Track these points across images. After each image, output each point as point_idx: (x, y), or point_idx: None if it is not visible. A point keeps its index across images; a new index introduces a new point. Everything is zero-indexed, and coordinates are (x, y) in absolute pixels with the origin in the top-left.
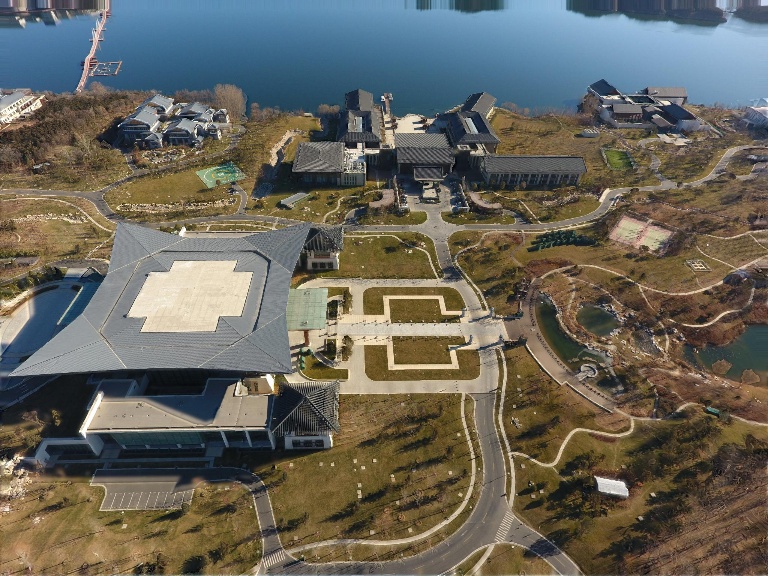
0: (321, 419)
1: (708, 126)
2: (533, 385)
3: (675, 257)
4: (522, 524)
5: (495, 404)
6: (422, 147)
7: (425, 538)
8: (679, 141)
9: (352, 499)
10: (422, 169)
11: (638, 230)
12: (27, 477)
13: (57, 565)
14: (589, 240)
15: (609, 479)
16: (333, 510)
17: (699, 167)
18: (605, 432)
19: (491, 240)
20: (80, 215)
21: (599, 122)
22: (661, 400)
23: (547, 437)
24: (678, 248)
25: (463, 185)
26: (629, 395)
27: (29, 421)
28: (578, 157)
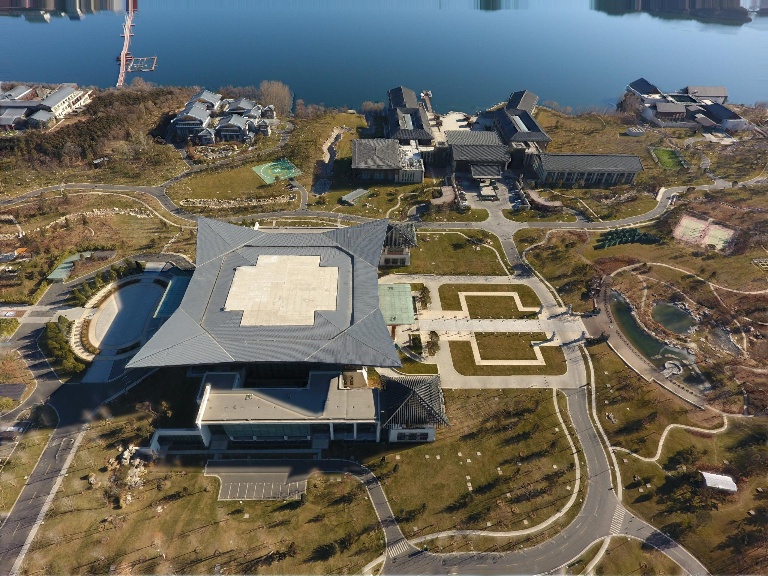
0: (430, 412)
1: (752, 126)
2: (622, 381)
3: (741, 256)
4: (634, 517)
5: (587, 399)
6: (476, 145)
7: (541, 530)
8: (725, 140)
9: (463, 491)
10: (479, 167)
11: (700, 229)
12: (142, 467)
13: (190, 552)
14: (654, 238)
15: (714, 474)
16: (447, 502)
17: (750, 167)
18: (700, 428)
19: (556, 238)
20: (145, 210)
21: (642, 121)
22: (750, 397)
23: (644, 432)
24: (744, 247)
25: (521, 183)
26: (717, 392)
27: (137, 412)
28: (634, 156)
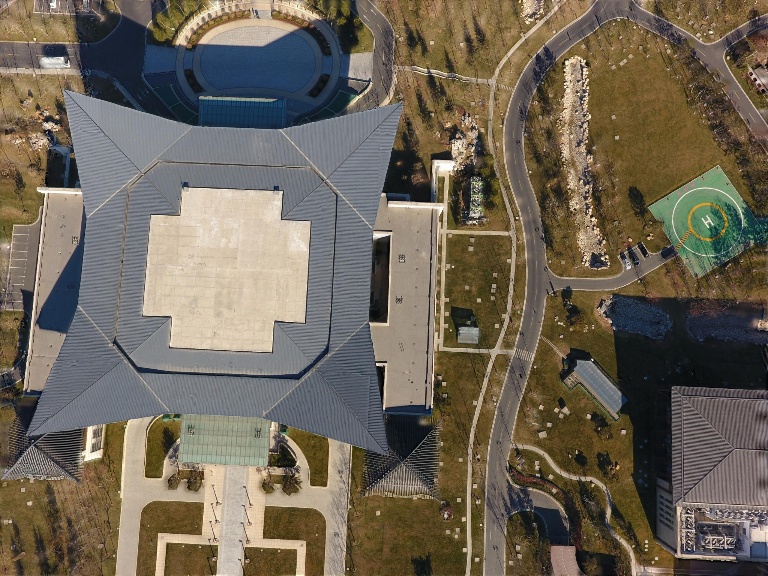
0: None
1: None
2: None
3: None
4: None
5: None
6: None
7: None
8: None
9: None
10: None
11: None
12: None
13: None
14: None
15: None
16: None
17: None
18: None
19: None
20: (548, 4)
21: None
22: None
23: None
24: None
25: None
26: None
27: None
28: None
